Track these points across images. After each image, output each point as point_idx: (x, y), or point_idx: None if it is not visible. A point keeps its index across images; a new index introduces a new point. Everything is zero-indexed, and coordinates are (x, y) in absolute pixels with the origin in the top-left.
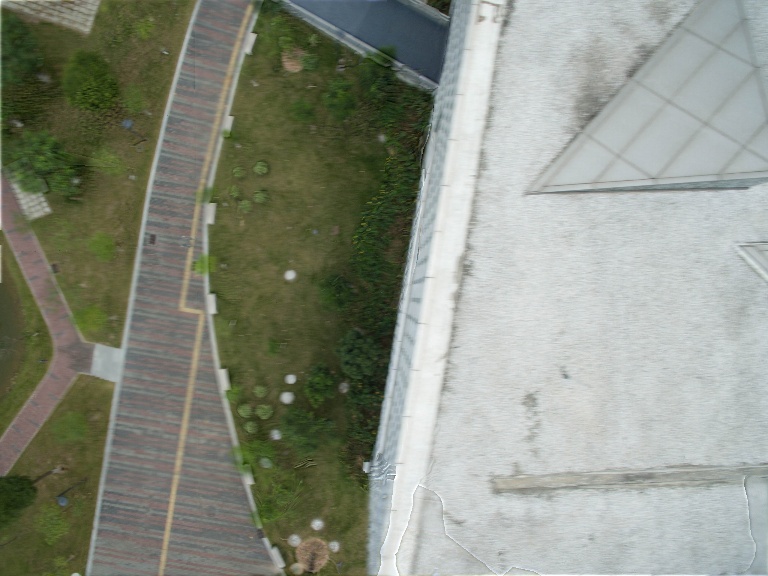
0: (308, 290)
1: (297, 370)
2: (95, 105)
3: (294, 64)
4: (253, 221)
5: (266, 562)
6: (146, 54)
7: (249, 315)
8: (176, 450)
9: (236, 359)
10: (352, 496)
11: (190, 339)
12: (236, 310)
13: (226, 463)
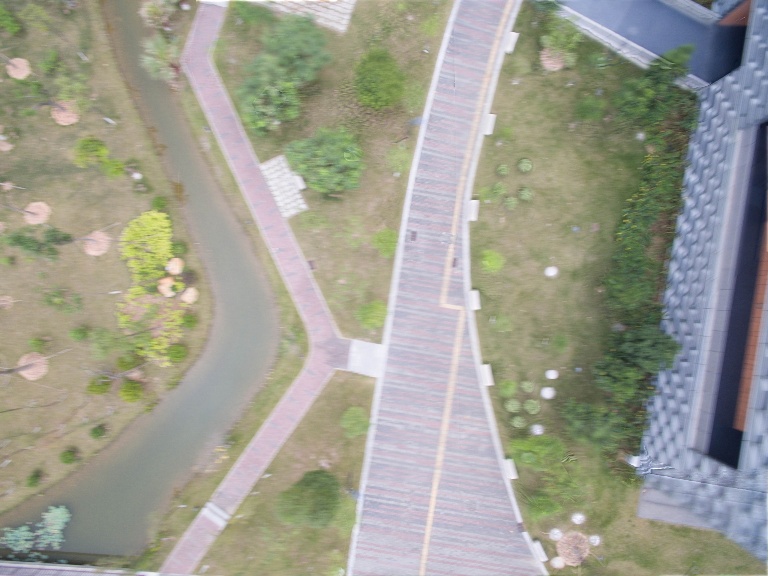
0: (570, 286)
1: (558, 365)
2: (354, 103)
3: (553, 63)
4: (514, 218)
5: (526, 556)
6: (406, 52)
7: (509, 311)
8: (437, 445)
9: (497, 355)
10: (613, 490)
11: (451, 335)
12: (496, 306)
13: (486, 458)
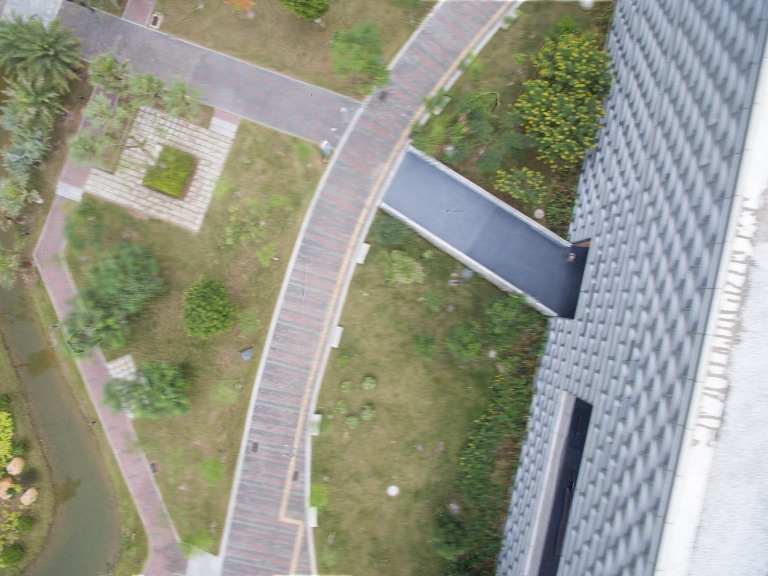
0: (411, 508)
1: None
2: (202, 307)
3: (405, 275)
4: (357, 434)
5: None
6: (256, 259)
7: (349, 528)
8: None
9: (334, 573)
10: None
11: (288, 550)
12: (336, 522)
13: None
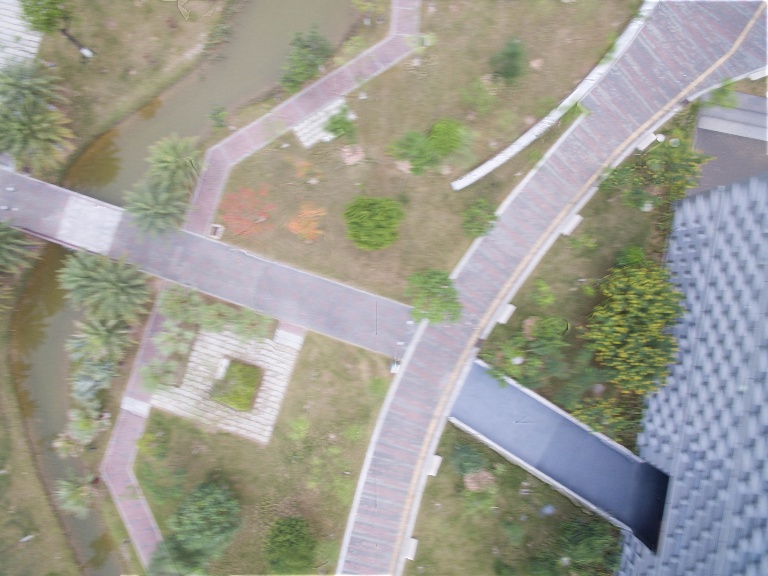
0: None
1: None
2: (274, 521)
3: (476, 485)
4: None
5: None
6: (327, 473)
7: None
8: None
9: None
10: None
11: None
12: None
13: None
